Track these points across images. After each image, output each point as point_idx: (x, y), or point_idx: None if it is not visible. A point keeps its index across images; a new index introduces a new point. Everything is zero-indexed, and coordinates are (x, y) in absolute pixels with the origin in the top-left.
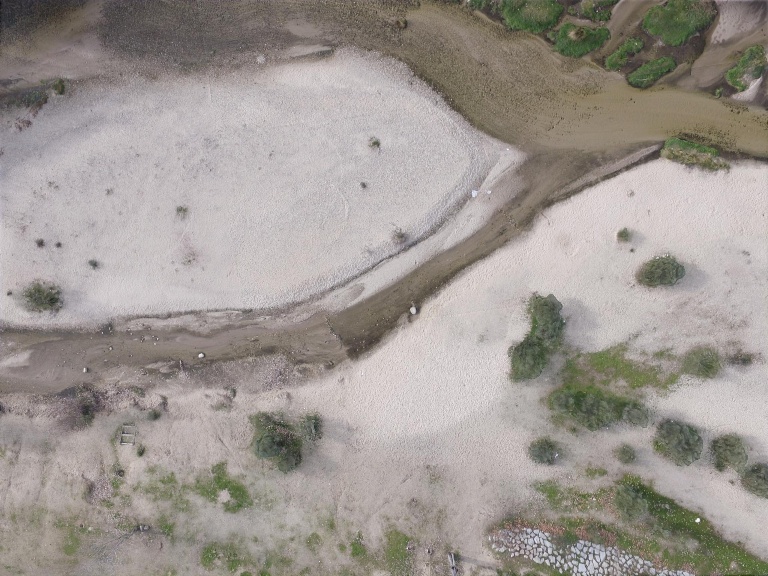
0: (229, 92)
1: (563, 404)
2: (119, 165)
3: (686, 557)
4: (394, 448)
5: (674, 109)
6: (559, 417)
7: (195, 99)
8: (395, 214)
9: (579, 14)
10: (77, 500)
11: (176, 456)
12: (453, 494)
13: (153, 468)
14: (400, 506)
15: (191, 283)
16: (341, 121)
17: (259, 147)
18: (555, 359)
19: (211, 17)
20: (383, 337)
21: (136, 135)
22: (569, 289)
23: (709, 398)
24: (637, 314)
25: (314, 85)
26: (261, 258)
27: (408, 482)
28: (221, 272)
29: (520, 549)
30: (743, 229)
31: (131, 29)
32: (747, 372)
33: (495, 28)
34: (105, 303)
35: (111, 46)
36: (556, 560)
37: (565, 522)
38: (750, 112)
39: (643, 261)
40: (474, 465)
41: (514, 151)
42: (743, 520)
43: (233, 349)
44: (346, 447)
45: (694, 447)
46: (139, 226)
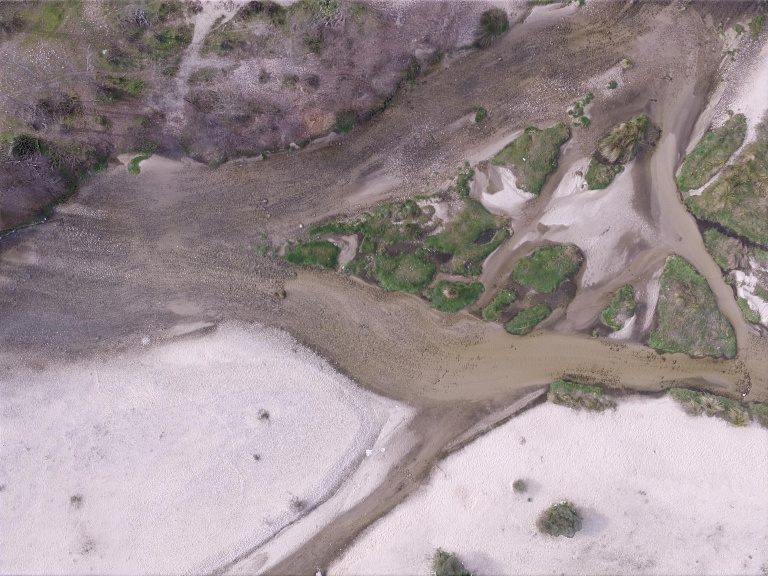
0: (116, 376)
1: None
2: (10, 461)
3: None
4: None
5: (555, 352)
6: None
7: (83, 387)
8: (291, 483)
9: (451, 271)
10: None
11: None
12: None
13: None
14: None
15: (90, 572)
16: (228, 396)
17: (149, 430)
18: None
19: (94, 304)
20: None
21: (25, 429)
22: (472, 542)
23: None
24: (543, 562)
25: (200, 362)
26: (159, 540)
27: None
28: (120, 558)
29: None
30: (636, 469)
31: (16, 323)
32: None
33: (372, 290)
34: None
35: None
36: None
37: None
38: (629, 348)
39: (542, 509)
40: None
41: (403, 407)
42: None
43: None
44: None
45: None
46: (34, 520)
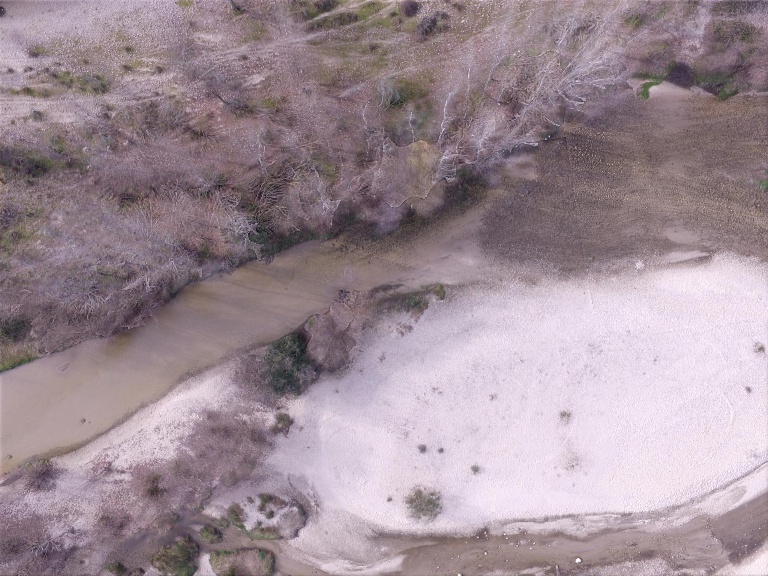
0: (609, 297)
1: None
2: (503, 371)
3: None
4: None
5: None
6: None
7: (576, 305)
8: None
9: None
10: None
11: None
12: None
13: None
14: None
15: (572, 488)
16: (725, 327)
17: (644, 353)
18: None
19: (590, 225)
20: (766, 541)
21: (520, 341)
22: None
23: None
24: None
25: (694, 290)
26: (645, 463)
27: None
28: (604, 477)
29: None
30: None
31: (511, 237)
32: None
33: None
34: (484, 508)
35: (491, 253)
36: None
37: None
38: None
39: None
40: None
41: None
42: None
43: (611, 553)
44: None
45: None
46: (521, 431)
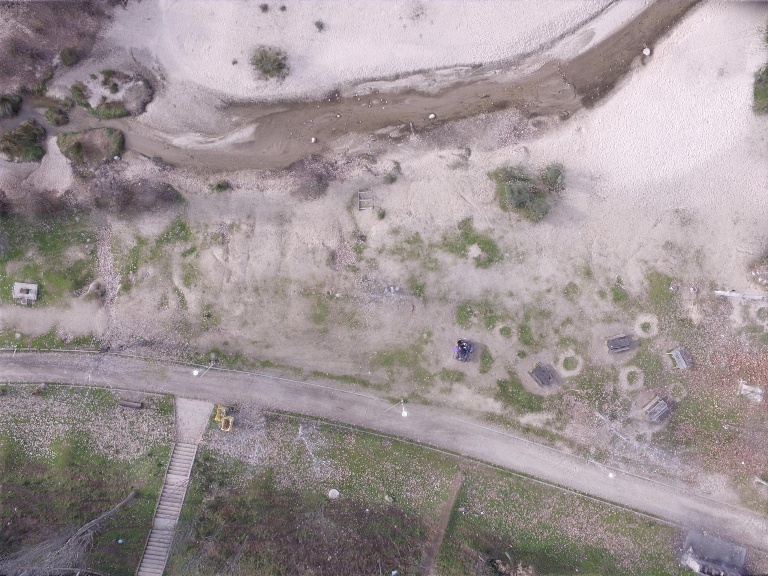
0: None
1: None
2: None
3: None
4: (640, 194)
5: None
6: None
7: None
8: None
9: None
10: (321, 267)
11: (419, 216)
12: (707, 234)
13: (397, 229)
14: (656, 249)
15: (420, 39)
16: None
17: None
18: None
19: None
20: (617, 82)
21: None
22: None
23: None
24: None
25: None
26: (490, 7)
27: (659, 226)
28: (450, 25)
29: None
30: None
31: None
32: None
33: None
34: (332, 67)
35: None
36: None
37: None
38: None
39: None
40: (724, 205)
41: None
42: None
43: (464, 107)
44: (591, 196)
45: None
46: None
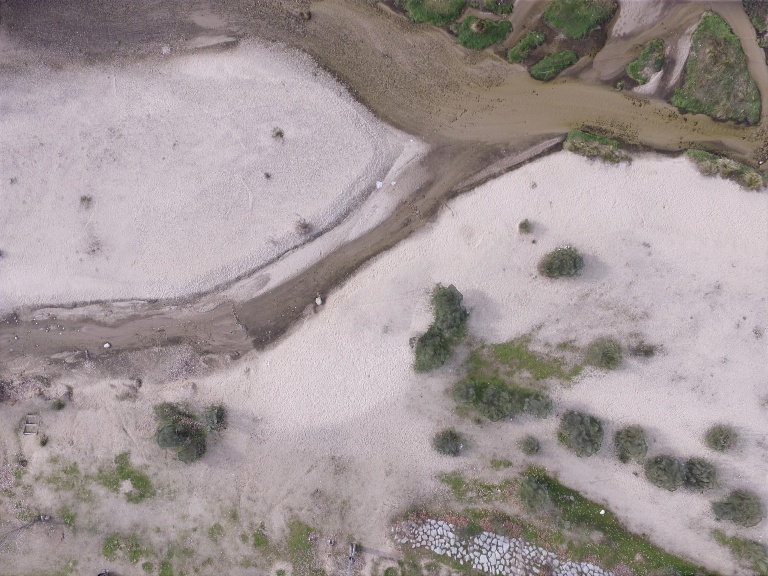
0: (134, 82)
1: (464, 395)
2: (23, 154)
3: (591, 549)
4: (299, 439)
5: (576, 102)
6: (464, 408)
7: (100, 89)
8: (299, 205)
9: (481, 7)
10: None
11: (79, 446)
12: (357, 485)
13: (56, 458)
14: (303, 497)
15: (96, 273)
16: (245, 111)
17: (163, 137)
18: (459, 350)
19: (116, 7)
20: (289, 328)
21: (40, 124)
22: (472, 280)
23: (612, 390)
24: (540, 305)
25: (218, 76)
26: (165, 248)
27: (313, 473)
28: (125, 262)
29: (422, 540)
30: (643, 221)
31: (36, 19)
32: (649, 364)
33: (398, 20)
34: (10, 292)
35: (16, 36)
36: (458, 551)
37: (470, 513)
38: (652, 105)
39: (545, 252)
40: (379, 456)
41: (418, 142)
42: (647, 512)
43: (139, 339)
44: (251, 438)
45: (594, 438)
46: (43, 215)
